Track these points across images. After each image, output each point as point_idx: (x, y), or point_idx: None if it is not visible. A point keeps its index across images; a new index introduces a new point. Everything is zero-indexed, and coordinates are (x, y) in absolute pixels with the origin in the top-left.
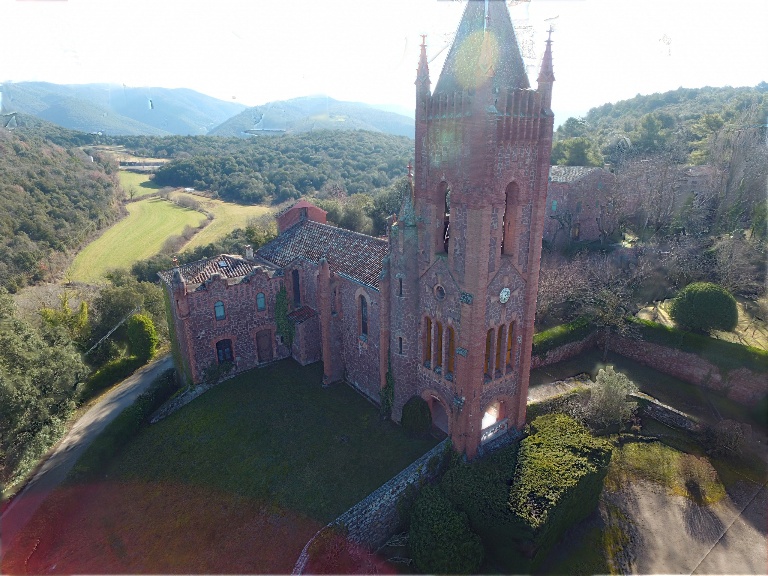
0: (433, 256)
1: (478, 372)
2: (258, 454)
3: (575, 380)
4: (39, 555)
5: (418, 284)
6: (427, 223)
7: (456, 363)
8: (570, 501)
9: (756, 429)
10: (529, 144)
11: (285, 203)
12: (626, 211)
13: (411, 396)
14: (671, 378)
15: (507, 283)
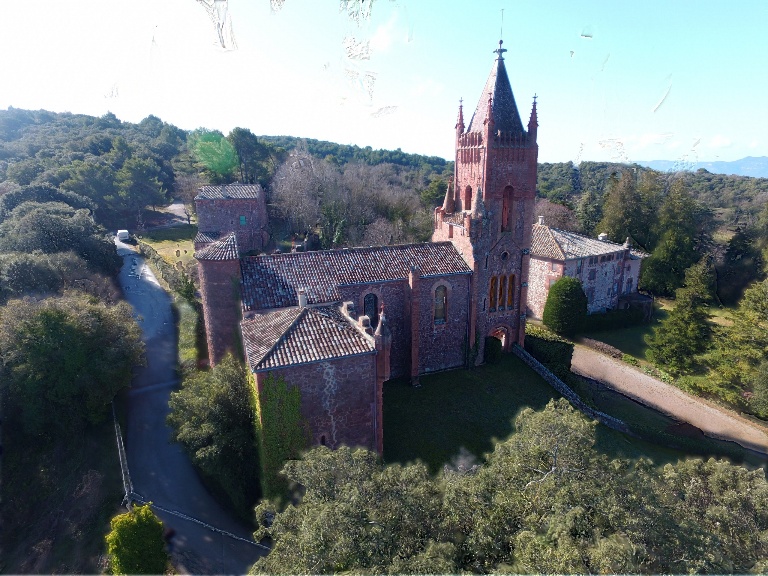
0: (500, 234)
1: None
2: (500, 431)
3: None
4: None
5: None
6: (496, 214)
7: (516, 295)
8: None
9: None
10: None
11: None
12: (308, 215)
13: (485, 339)
14: None
15: None
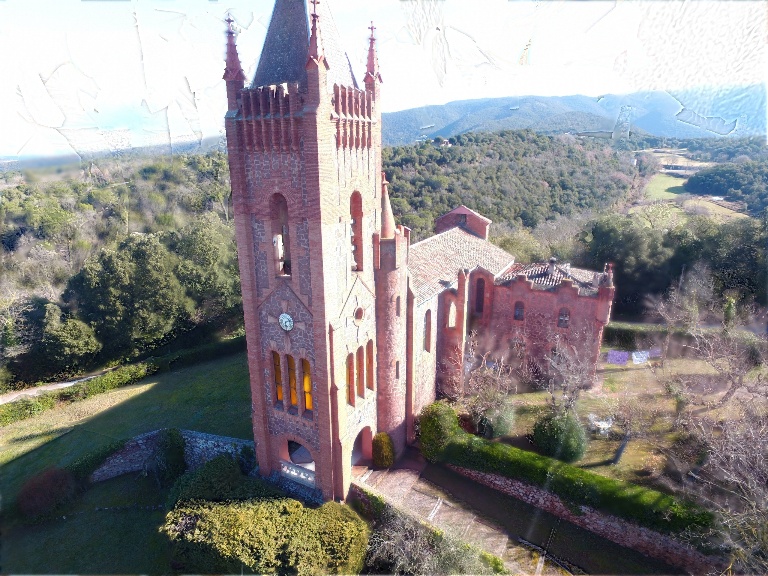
0: None
1: (256, 387)
2: None
3: (573, 574)
4: (180, 365)
5: None
6: None
7: None
8: (222, 569)
9: None
10: (294, 150)
11: (576, 214)
12: None
13: None
14: None
15: (288, 309)
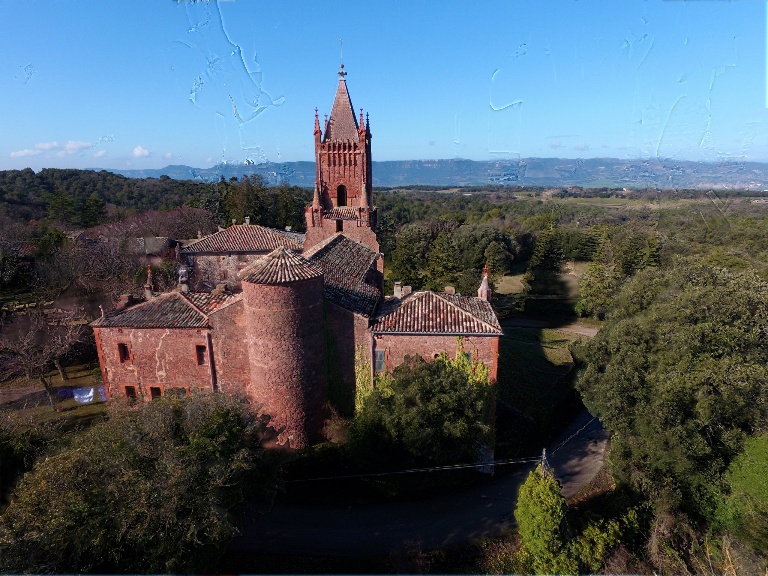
0: None
1: None
2: None
3: None
4: None
5: None
6: None
7: None
8: None
9: None
10: None
11: None
12: None
13: None
14: None
15: None
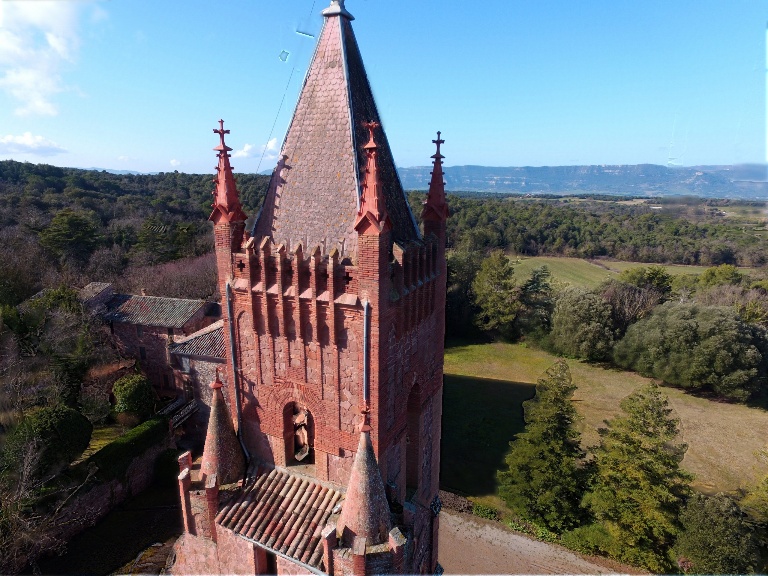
0: None
1: None
2: None
3: None
4: None
5: None
6: (397, 476)
7: None
8: None
9: None
10: None
11: None
12: None
13: None
14: (92, 531)
15: None
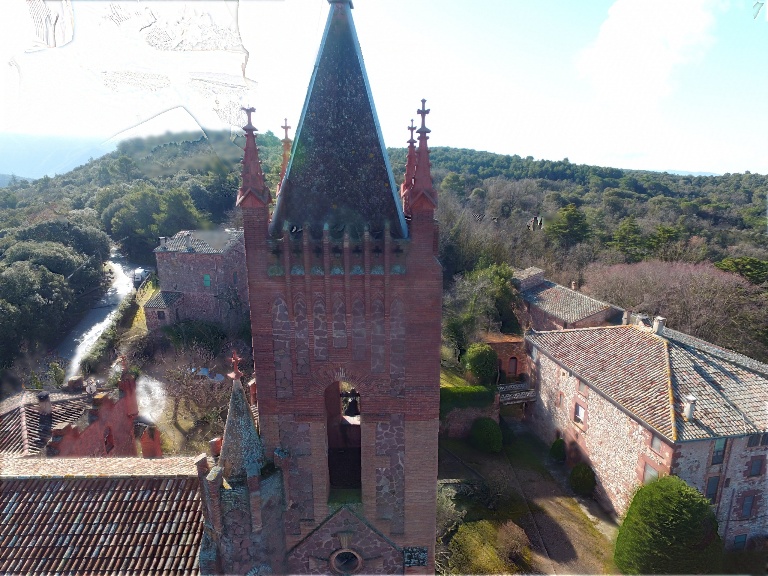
0: (324, 508)
1: None
2: None
3: None
4: None
5: (287, 562)
6: (301, 455)
7: None
8: None
9: (483, 457)
10: None
11: None
12: None
13: None
14: None
15: None
